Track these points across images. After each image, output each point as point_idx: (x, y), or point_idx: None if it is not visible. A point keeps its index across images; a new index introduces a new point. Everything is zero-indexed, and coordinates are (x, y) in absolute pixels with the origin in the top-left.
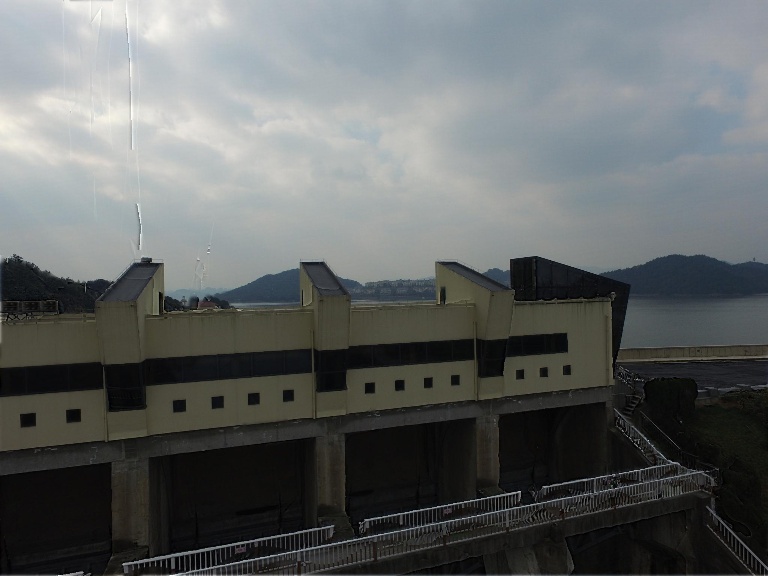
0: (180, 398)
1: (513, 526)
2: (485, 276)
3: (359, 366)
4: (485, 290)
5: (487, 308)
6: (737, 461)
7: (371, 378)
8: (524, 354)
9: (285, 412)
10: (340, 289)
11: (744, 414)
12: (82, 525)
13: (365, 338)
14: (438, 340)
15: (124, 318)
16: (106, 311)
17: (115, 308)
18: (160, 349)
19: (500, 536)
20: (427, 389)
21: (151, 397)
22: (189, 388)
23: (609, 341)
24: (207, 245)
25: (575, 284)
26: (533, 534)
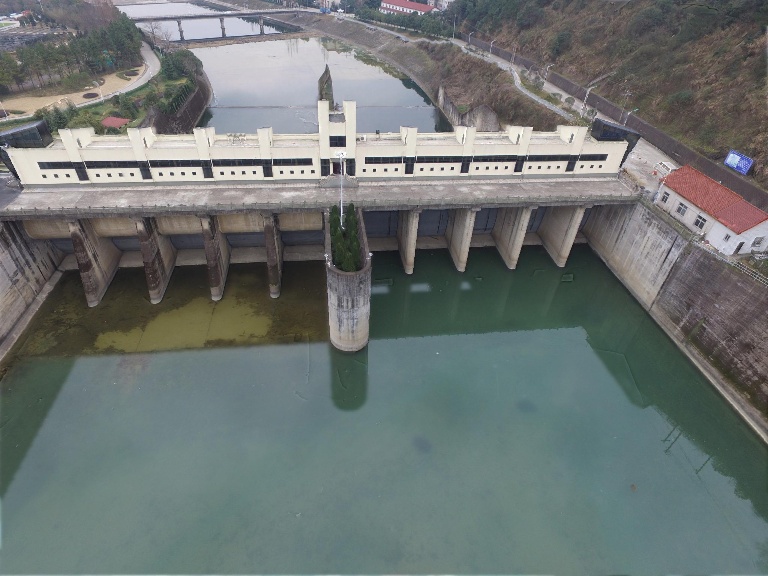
0: None
1: None
2: None
3: None
4: (92, 128)
5: None
6: None
7: None
8: None
9: None
10: None
11: None
12: None
13: None
14: None
15: None
16: None
17: None
18: None
19: None
20: None
21: None
22: None
23: None
24: None
25: None
26: None
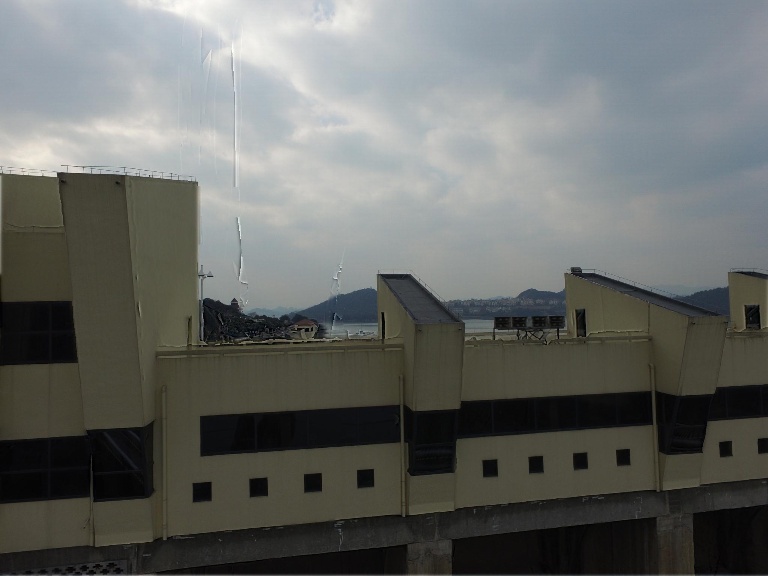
0: (726, 439)
1: None
2: None
3: None
4: None
5: None
6: None
7: None
8: None
9: None
10: None
11: None
12: (488, 575)
13: None
14: None
15: (712, 338)
16: (697, 328)
17: (707, 325)
18: None
19: None
20: None
21: None
22: (734, 426)
23: None
24: None
25: None
26: None
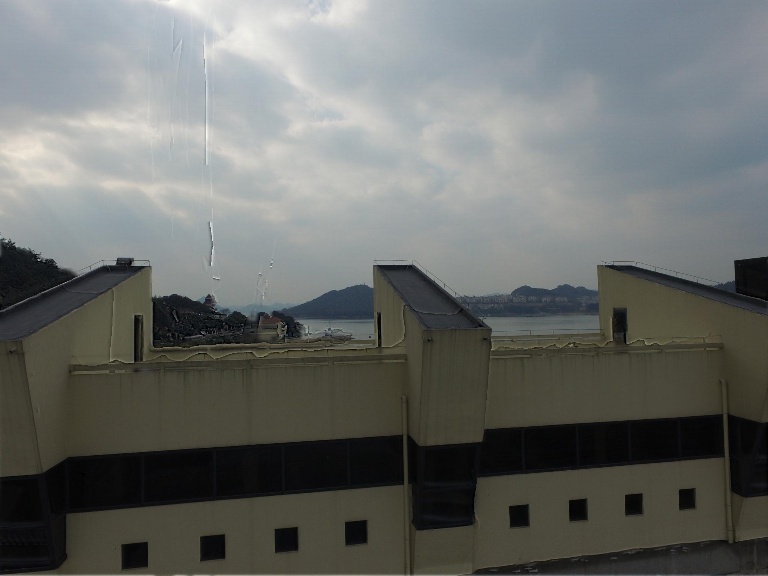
0: (136, 539)
1: None
2: None
3: (497, 470)
4: (762, 318)
5: None
6: None
7: (521, 495)
8: None
9: (349, 567)
10: (462, 314)
11: None
12: None
13: (508, 413)
14: (652, 417)
15: None
16: None
17: None
18: (99, 436)
19: None
20: (631, 517)
21: (77, 537)
22: (155, 517)
23: None
24: (270, 259)
25: None
26: None
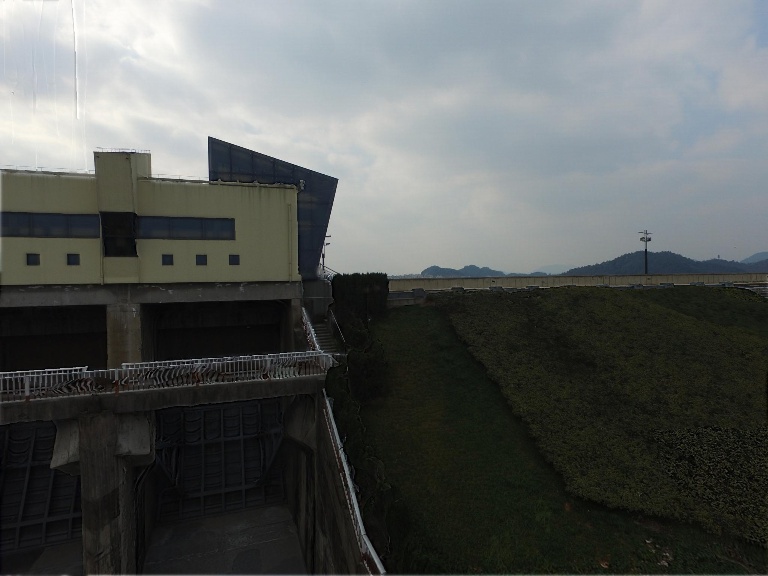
0: None
1: (38, 395)
2: (137, 153)
3: None
4: None
5: (94, 172)
6: (371, 343)
7: None
8: (174, 238)
9: None
10: None
11: (434, 310)
12: None
13: None
14: (48, 212)
15: None
16: None
17: None
18: None
19: (15, 405)
20: (32, 267)
21: None
22: None
23: (293, 232)
24: None
25: (264, 172)
26: (67, 406)
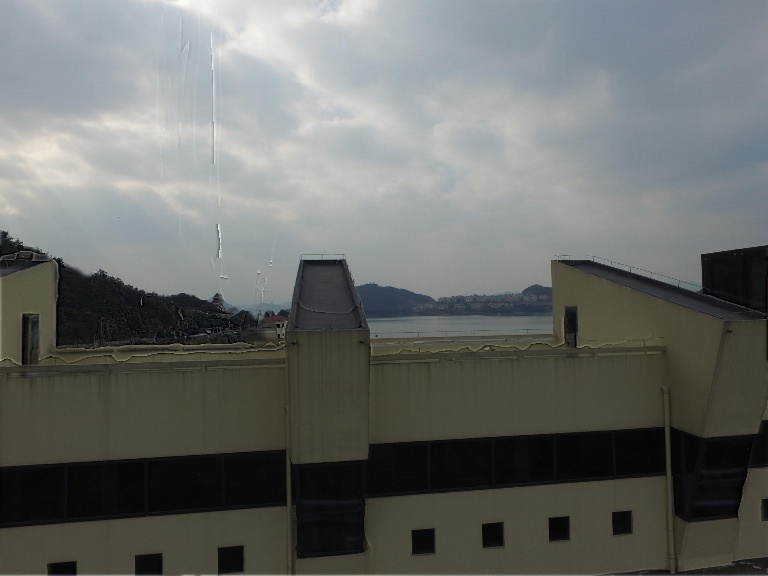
0: None
1: None
2: None
3: (398, 489)
4: (703, 317)
5: (711, 362)
6: None
7: (426, 518)
8: None
9: None
10: (352, 313)
11: None
12: None
13: (412, 425)
14: (581, 430)
15: None
16: None
17: None
18: None
19: None
20: (556, 543)
21: None
22: None
23: None
24: (269, 258)
25: None
26: None
